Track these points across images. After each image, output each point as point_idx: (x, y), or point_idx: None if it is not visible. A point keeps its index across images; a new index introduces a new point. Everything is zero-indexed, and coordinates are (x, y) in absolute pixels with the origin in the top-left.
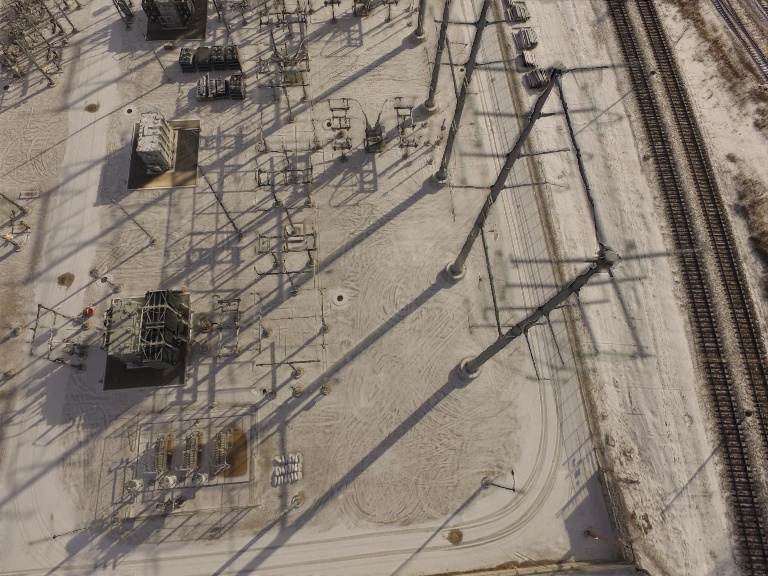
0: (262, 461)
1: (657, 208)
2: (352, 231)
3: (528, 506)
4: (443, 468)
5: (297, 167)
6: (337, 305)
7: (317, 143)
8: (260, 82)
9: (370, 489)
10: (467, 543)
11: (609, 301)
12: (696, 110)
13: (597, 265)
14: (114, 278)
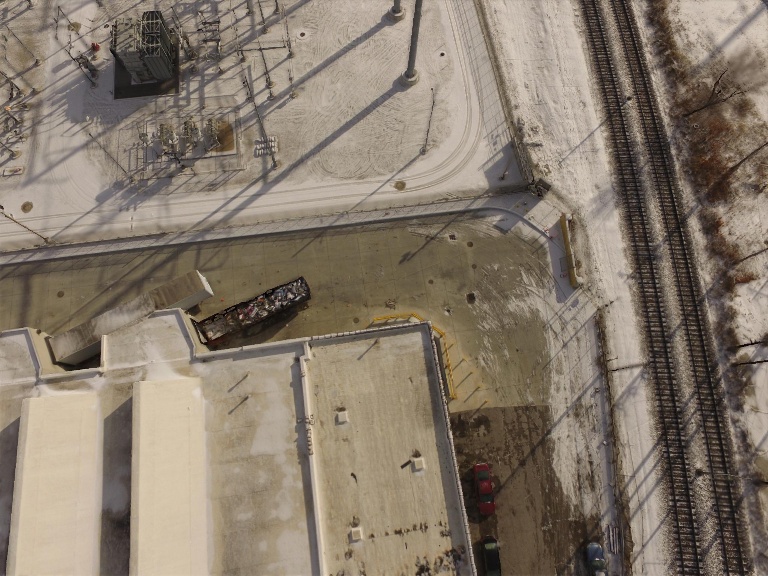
0: (246, 142)
1: None
2: None
3: (456, 164)
4: (389, 143)
5: None
6: (300, 39)
7: None
8: None
9: (332, 157)
10: (409, 189)
11: (522, 32)
12: None
13: None
14: None
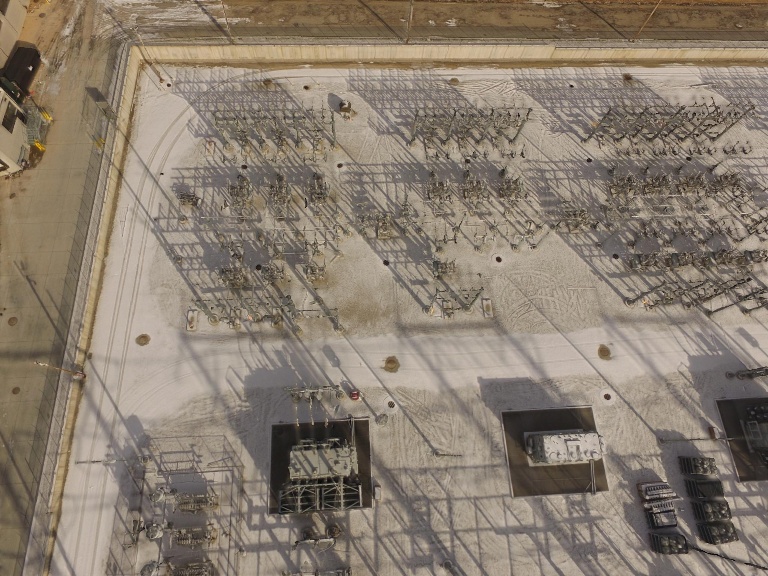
0: None
1: None
2: None
3: None
4: None
5: None
6: None
7: None
8: (686, 573)
9: None
10: None
11: None
12: None
13: None
14: (393, 415)
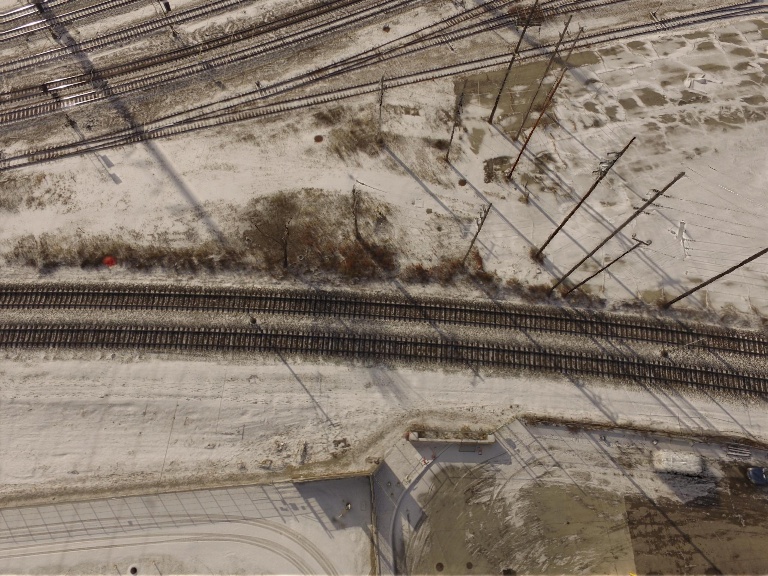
0: None
1: (21, 358)
2: None
3: (322, 571)
4: None
5: None
6: None
7: None
8: None
9: None
10: None
11: (120, 437)
12: None
13: None
14: None
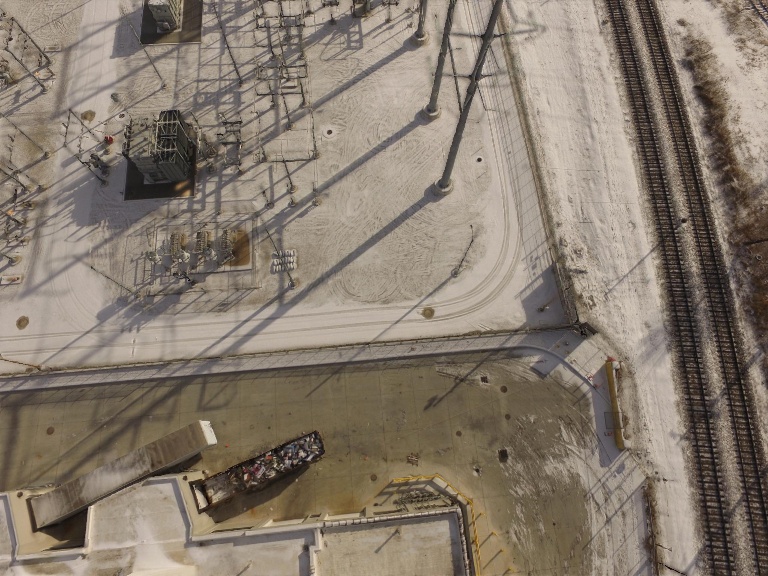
0: (262, 255)
1: (613, 63)
2: (340, 80)
3: (491, 290)
4: (418, 262)
5: (291, 28)
6: (327, 137)
7: (309, 9)
8: None
9: (355, 277)
10: (438, 317)
11: (567, 136)
12: None
13: None
14: (130, 115)
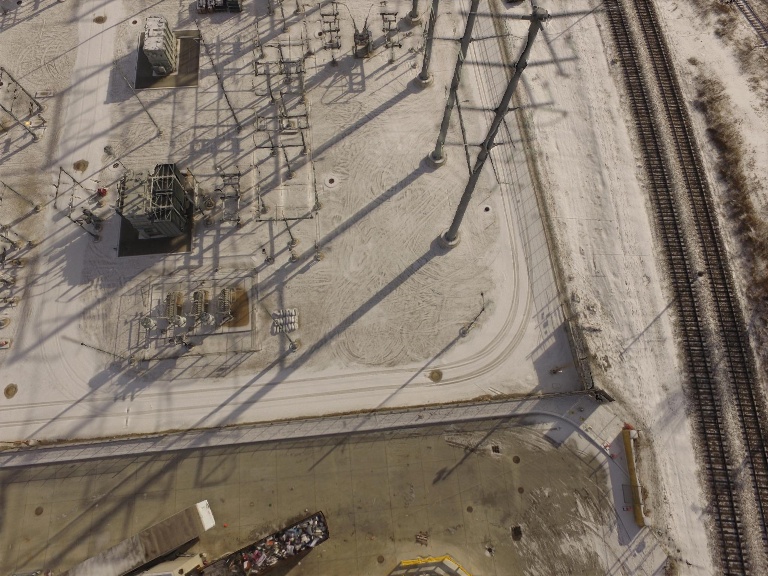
0: (262, 314)
1: (623, 104)
2: (342, 125)
3: (501, 351)
4: (425, 320)
5: (291, 70)
6: (329, 187)
7: (309, 50)
8: None
9: (360, 337)
10: (446, 381)
11: (577, 183)
12: (661, 21)
13: (531, 23)
14: (125, 164)
